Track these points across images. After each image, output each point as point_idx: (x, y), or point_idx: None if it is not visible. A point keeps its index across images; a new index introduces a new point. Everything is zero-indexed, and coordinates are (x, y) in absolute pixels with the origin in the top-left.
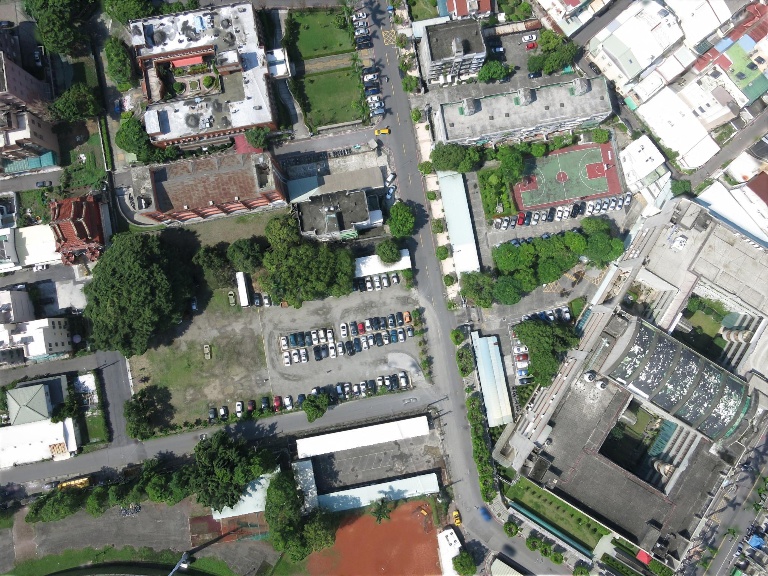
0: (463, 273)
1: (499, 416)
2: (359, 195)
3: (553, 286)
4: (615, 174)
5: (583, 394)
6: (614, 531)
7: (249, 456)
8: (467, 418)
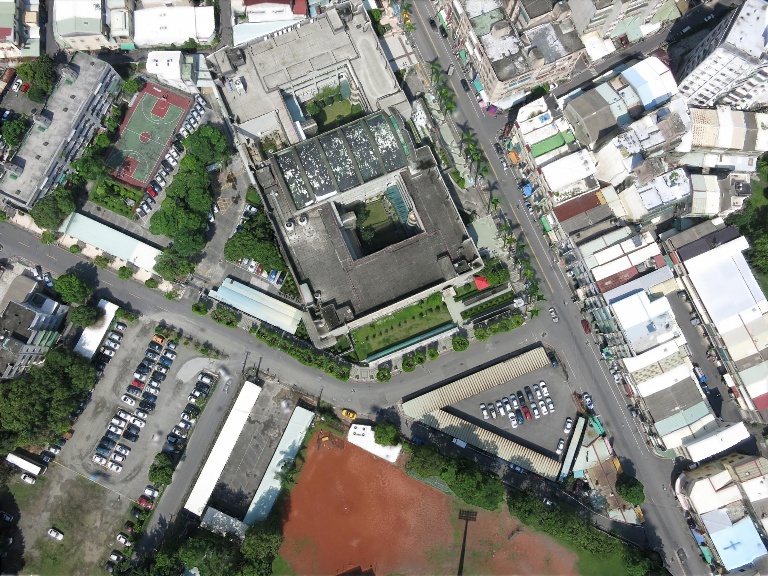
0: (153, 268)
1: (290, 320)
2: (12, 307)
3: (223, 204)
4: (175, 96)
5: (302, 240)
6: (421, 292)
7: (154, 560)
8: (275, 348)
